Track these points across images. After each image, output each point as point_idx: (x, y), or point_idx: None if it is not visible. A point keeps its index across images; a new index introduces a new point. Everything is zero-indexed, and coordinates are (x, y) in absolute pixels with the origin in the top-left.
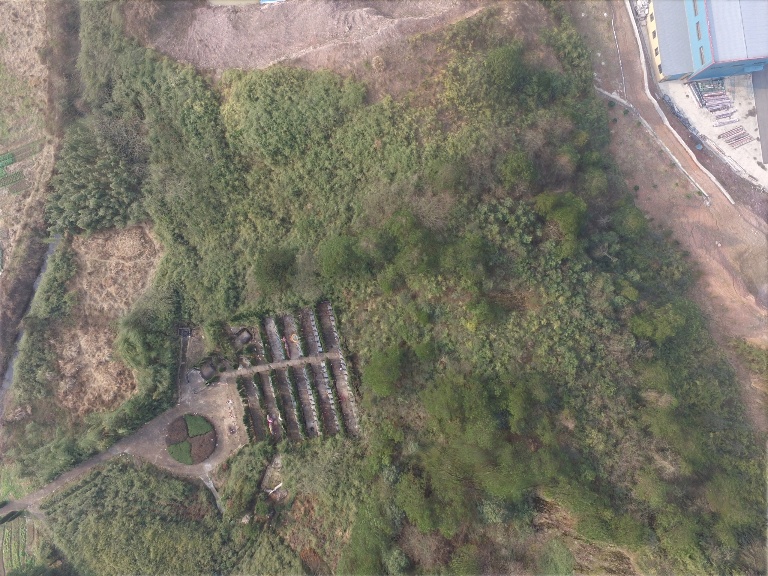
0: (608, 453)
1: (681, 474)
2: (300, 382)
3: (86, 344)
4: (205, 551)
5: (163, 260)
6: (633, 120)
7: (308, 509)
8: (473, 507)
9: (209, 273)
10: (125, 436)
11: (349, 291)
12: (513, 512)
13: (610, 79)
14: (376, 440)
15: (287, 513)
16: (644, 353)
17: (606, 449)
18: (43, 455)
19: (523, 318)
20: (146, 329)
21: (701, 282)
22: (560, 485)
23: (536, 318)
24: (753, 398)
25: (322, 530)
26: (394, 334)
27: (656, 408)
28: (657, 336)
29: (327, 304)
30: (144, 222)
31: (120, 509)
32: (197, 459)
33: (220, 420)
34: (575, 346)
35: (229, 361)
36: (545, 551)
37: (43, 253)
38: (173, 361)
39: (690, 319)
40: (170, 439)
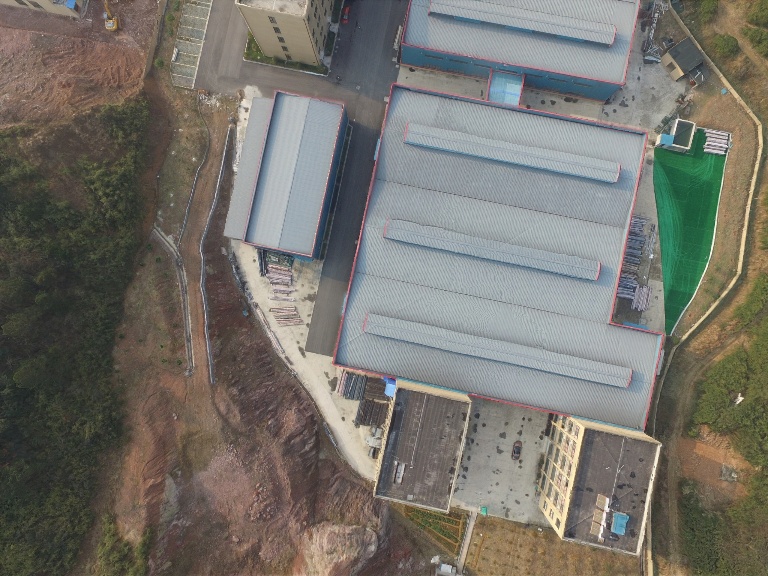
0: None
1: None
2: None
3: None
4: None
5: None
6: (169, 269)
7: None
8: None
9: None
10: None
11: None
12: None
13: (172, 222)
14: None
15: None
16: None
17: None
18: None
19: None
20: None
21: (126, 448)
22: None
23: None
24: None
25: None
26: None
27: None
28: None
29: None
30: None
31: None
32: None
33: None
34: None
35: None
36: None
37: None
38: None
39: None
40: None
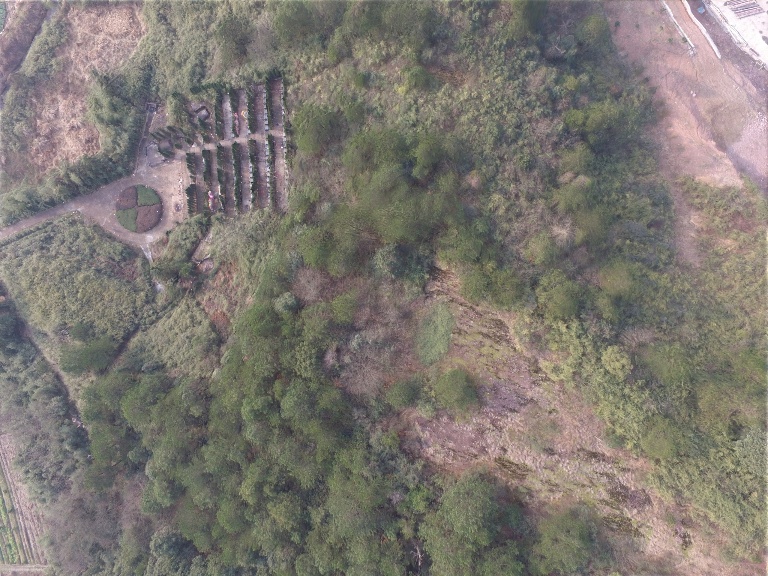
0: (508, 221)
1: (576, 246)
2: (244, 160)
3: (63, 108)
4: (128, 304)
5: (144, 37)
6: None
7: (228, 279)
8: (365, 254)
9: (181, 49)
10: (80, 194)
11: (299, 62)
12: (404, 268)
13: None
14: (295, 202)
15: (209, 281)
16: (572, 144)
17: (507, 217)
18: (6, 197)
19: (455, 90)
20: (114, 91)
21: (664, 123)
22: (449, 232)
23: (467, 90)
24: (688, 232)
25: (235, 297)
26: (332, 103)
27: (568, 188)
28: (587, 124)
29: (280, 82)
30: (135, 3)
31: (62, 255)
32: (140, 227)
33: (169, 196)
34: (500, 121)
35: (184, 135)
36: (429, 315)
37: (42, 21)
38: (134, 128)
39: (627, 115)
40: (120, 204)
